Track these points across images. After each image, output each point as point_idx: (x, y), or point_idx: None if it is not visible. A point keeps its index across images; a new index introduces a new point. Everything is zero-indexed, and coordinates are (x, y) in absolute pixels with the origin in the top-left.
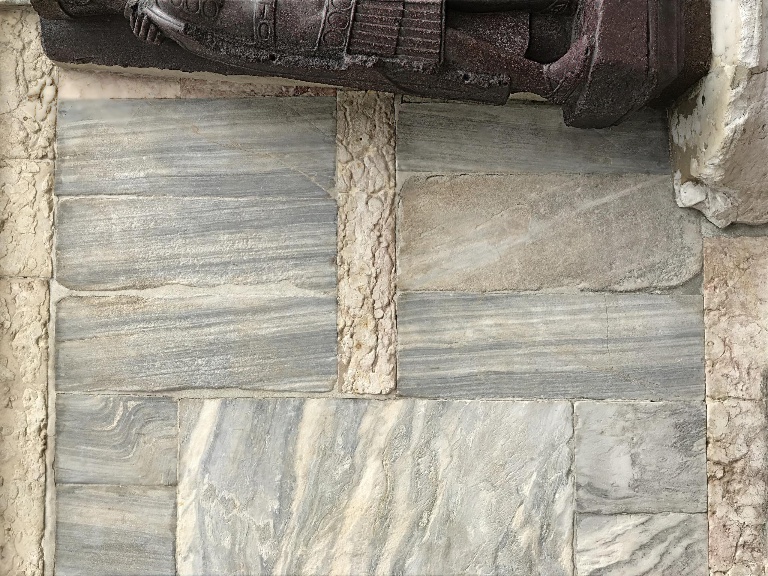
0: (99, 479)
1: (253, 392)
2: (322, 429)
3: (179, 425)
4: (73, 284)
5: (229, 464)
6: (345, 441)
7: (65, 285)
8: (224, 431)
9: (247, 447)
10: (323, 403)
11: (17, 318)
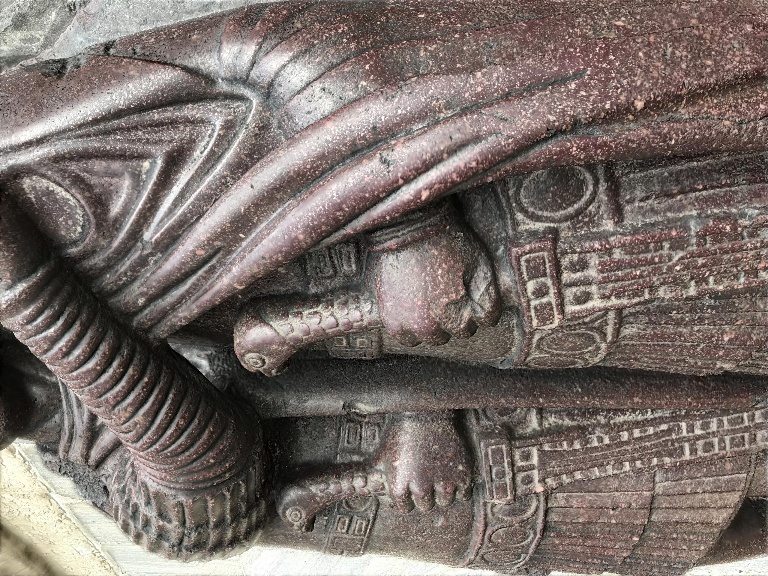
0: (167, 572)
1: (316, 552)
2: (389, 569)
3: (239, 556)
4: (81, 498)
5: (295, 574)
6: (412, 575)
7: (71, 497)
8: (287, 563)
9: (312, 570)
10: (392, 559)
11: (25, 509)
